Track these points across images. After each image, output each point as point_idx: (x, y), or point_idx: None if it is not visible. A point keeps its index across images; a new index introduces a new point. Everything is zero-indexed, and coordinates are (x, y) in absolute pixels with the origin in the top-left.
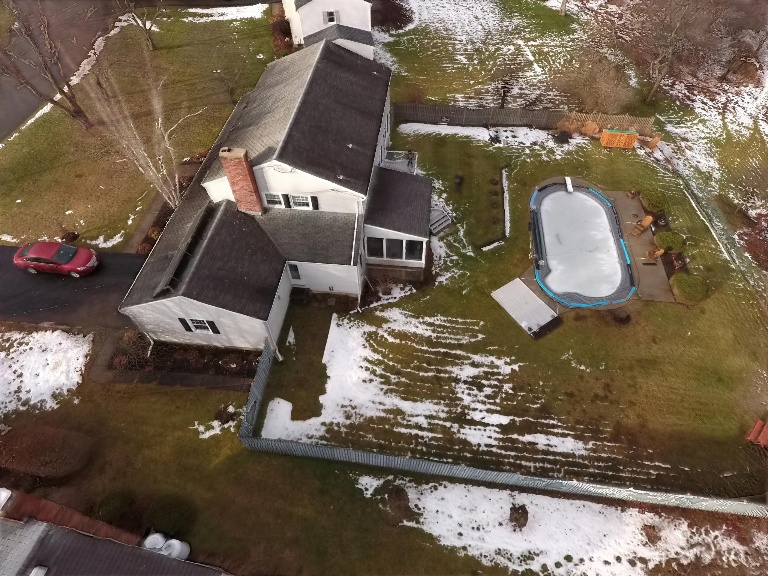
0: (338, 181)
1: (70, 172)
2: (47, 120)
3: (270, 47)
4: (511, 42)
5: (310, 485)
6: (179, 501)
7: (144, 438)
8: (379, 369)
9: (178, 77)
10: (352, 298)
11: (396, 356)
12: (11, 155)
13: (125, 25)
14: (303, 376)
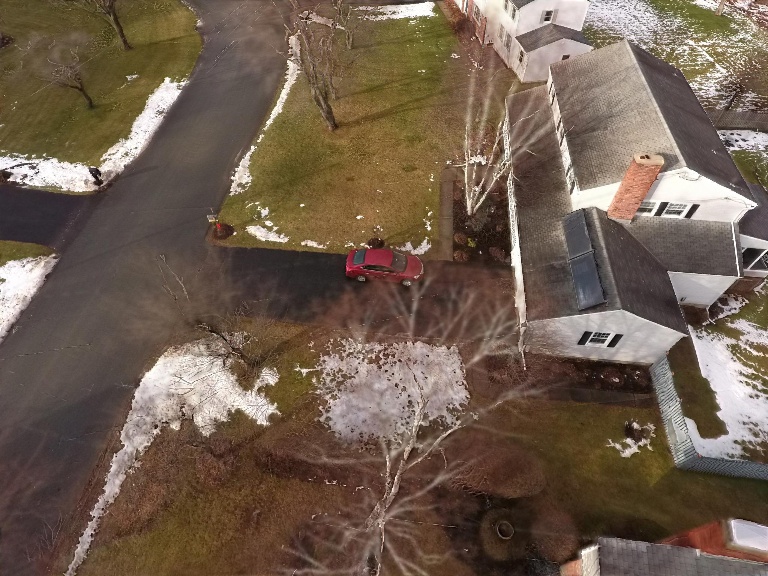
0: (734, 189)
1: (339, 175)
2: (286, 121)
3: (460, 46)
4: (683, 42)
5: (762, 508)
6: (659, 526)
7: (566, 457)
8: (759, 384)
9: (389, 77)
10: (698, 309)
11: (767, 370)
12: (270, 157)
13: (309, 23)
14: (691, 391)
